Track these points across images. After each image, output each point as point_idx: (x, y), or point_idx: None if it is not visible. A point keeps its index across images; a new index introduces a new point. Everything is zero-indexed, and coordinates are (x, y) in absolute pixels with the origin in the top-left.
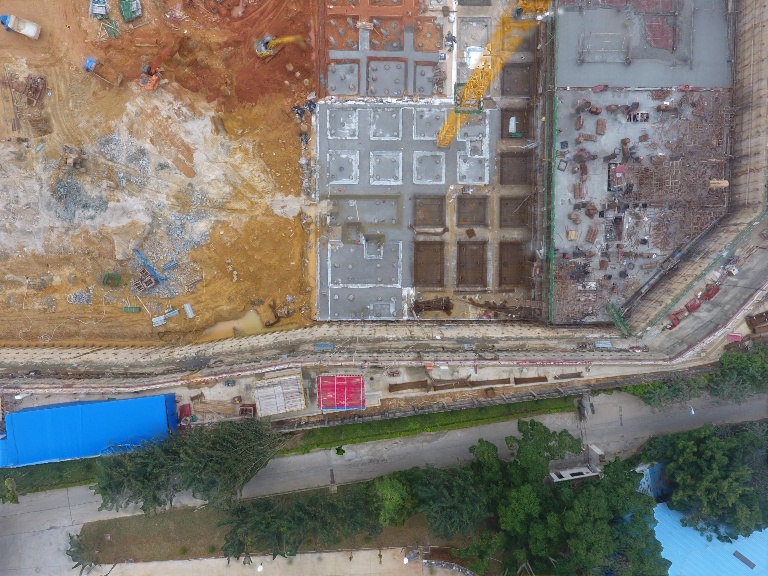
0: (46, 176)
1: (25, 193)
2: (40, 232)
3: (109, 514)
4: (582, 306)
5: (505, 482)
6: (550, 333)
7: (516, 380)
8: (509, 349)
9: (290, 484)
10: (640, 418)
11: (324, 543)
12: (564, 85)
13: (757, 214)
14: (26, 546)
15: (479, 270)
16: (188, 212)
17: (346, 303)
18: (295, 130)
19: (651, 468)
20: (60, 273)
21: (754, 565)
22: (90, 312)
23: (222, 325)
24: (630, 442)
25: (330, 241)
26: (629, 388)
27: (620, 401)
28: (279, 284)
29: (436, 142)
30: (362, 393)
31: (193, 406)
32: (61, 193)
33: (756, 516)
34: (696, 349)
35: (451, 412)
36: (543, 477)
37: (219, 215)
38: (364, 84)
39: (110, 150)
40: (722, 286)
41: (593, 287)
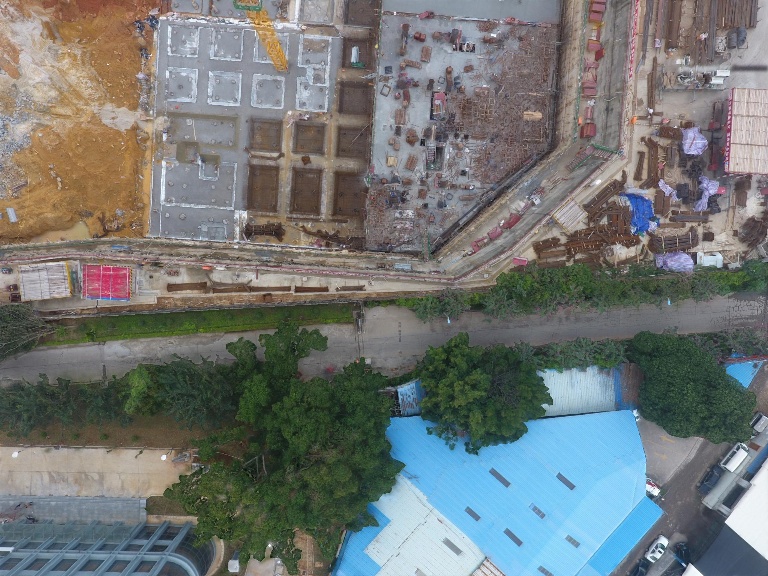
0: None
1: None
2: None
3: None
4: (398, 234)
5: None
6: (353, 253)
7: (296, 288)
8: (304, 263)
9: (61, 377)
10: (419, 335)
11: None
12: (391, 10)
13: (565, 146)
14: None
15: (315, 199)
16: (11, 113)
17: (177, 222)
18: (134, 44)
19: (417, 382)
20: None
21: (509, 483)
22: None
23: (50, 235)
24: (408, 359)
25: (165, 158)
26: (400, 300)
27: (400, 317)
28: (107, 196)
29: (275, 66)
30: (128, 285)
31: None
32: None
33: (489, 422)
34: (479, 270)
35: (226, 314)
36: (290, 375)
37: (43, 119)
38: (207, 3)
39: None
40: (524, 215)
41: (410, 215)
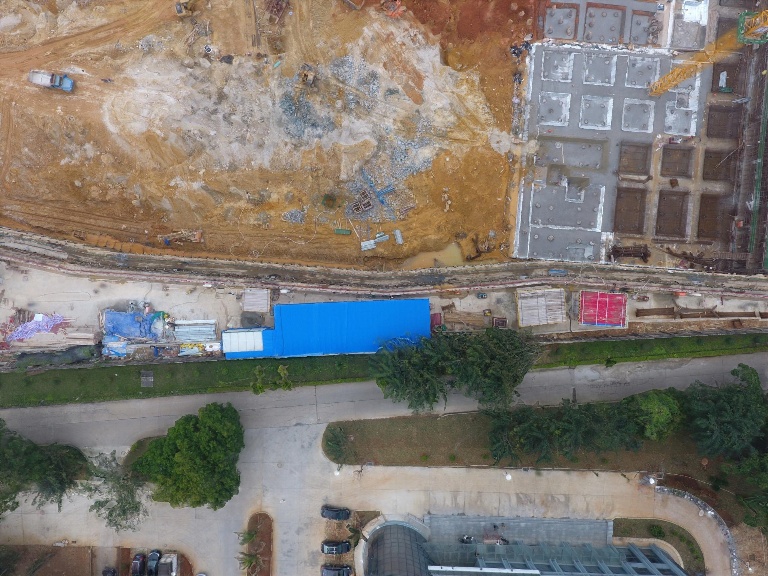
0: (280, 93)
1: (259, 107)
2: (271, 146)
3: (354, 415)
4: None
5: (767, 406)
6: None
7: (762, 314)
8: (742, 288)
9: (532, 400)
10: None
11: (586, 452)
12: None
13: None
14: (271, 441)
15: (677, 221)
16: (413, 138)
17: (545, 243)
18: (511, 69)
19: None
20: (278, 190)
21: None
22: (300, 232)
23: (423, 255)
24: None
25: (535, 181)
26: None
27: None
28: (485, 218)
29: (648, 90)
30: (623, 311)
31: (443, 315)
32: (292, 110)
33: None
34: None
35: (699, 340)
36: None
37: (442, 143)
38: (582, 29)
39: (343, 72)
40: None
41: None
